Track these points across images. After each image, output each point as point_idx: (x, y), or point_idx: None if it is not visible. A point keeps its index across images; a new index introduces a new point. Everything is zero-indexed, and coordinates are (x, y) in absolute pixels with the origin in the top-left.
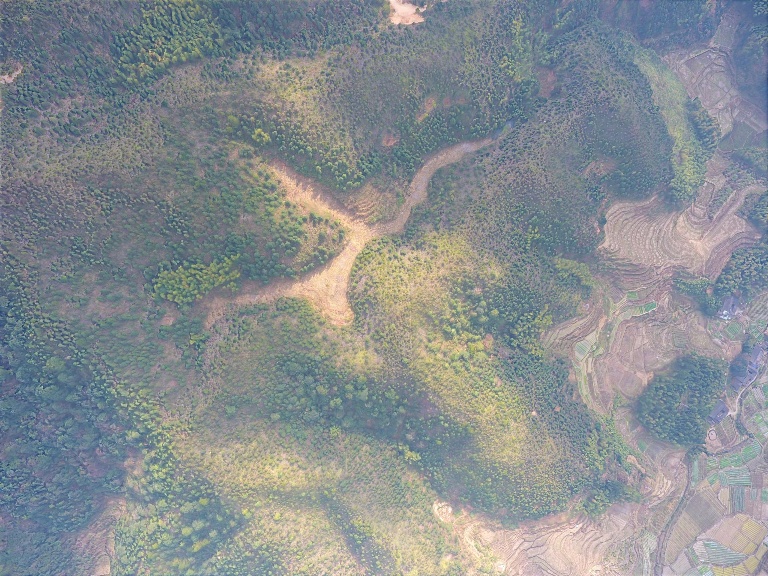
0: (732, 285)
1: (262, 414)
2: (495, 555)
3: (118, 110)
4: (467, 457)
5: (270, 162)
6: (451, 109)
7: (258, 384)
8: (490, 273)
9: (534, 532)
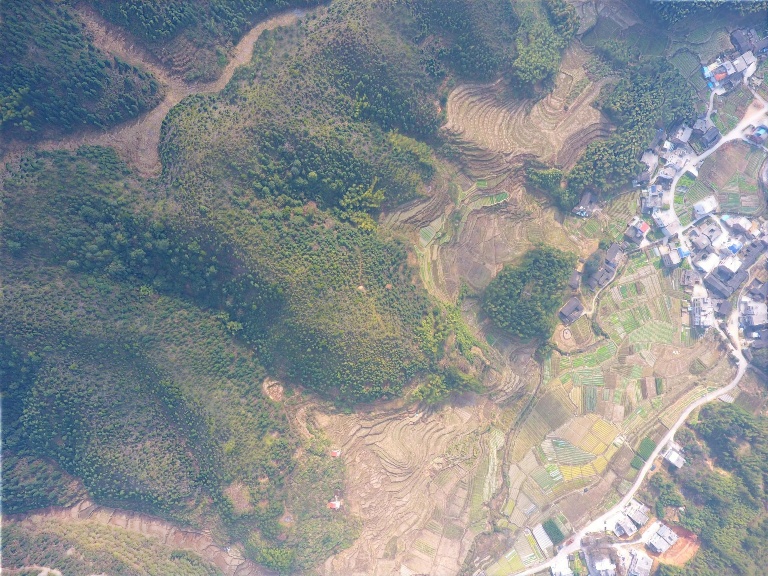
0: (584, 176)
1: (59, 261)
2: (329, 439)
3: None
4: (283, 323)
5: (75, 5)
6: None
7: (46, 222)
8: (302, 130)
9: (371, 418)
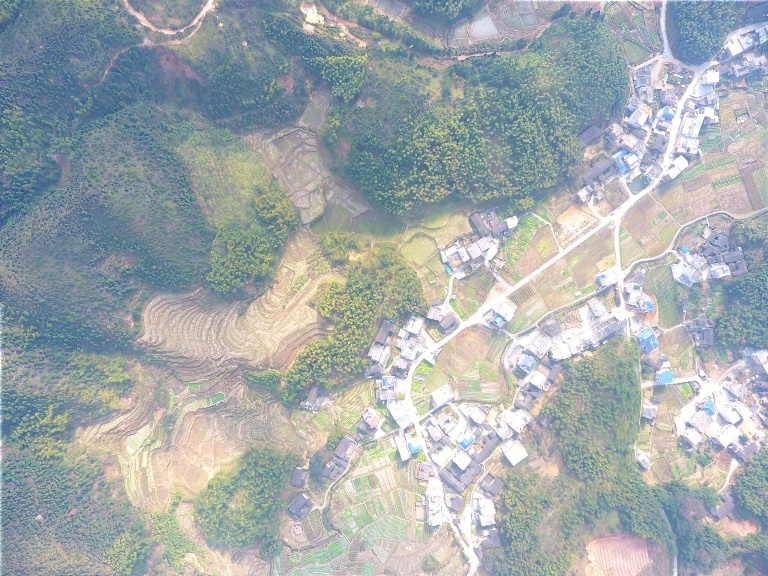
0: (299, 379)
1: None
2: None
3: None
4: None
5: None
6: None
7: None
8: None
9: None
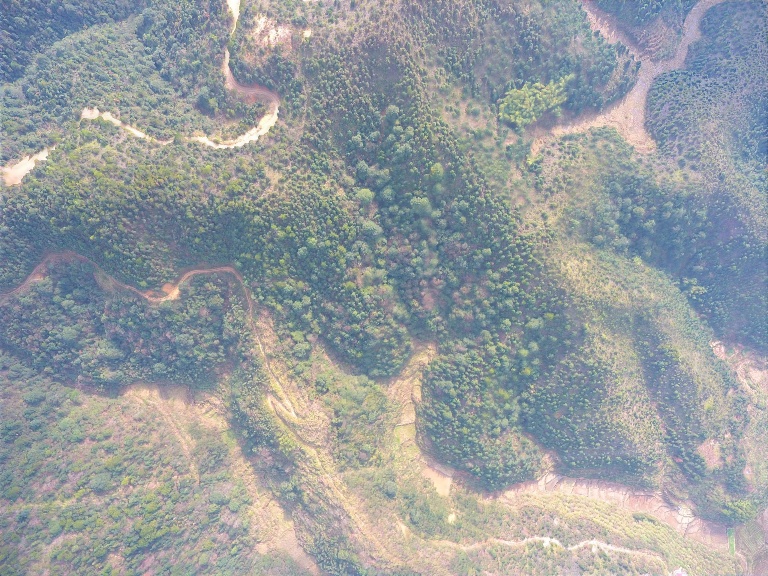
0: None
1: (586, 237)
2: (764, 393)
3: None
4: (760, 281)
5: None
6: None
7: None
8: None
9: None
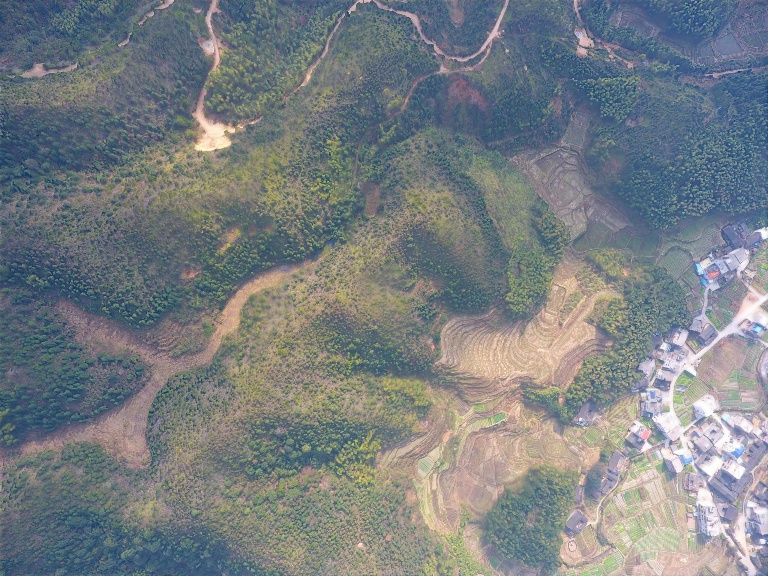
0: (582, 395)
1: (46, 570)
2: None
3: None
4: None
5: (55, 303)
6: (257, 237)
7: (31, 545)
8: (294, 411)
9: None
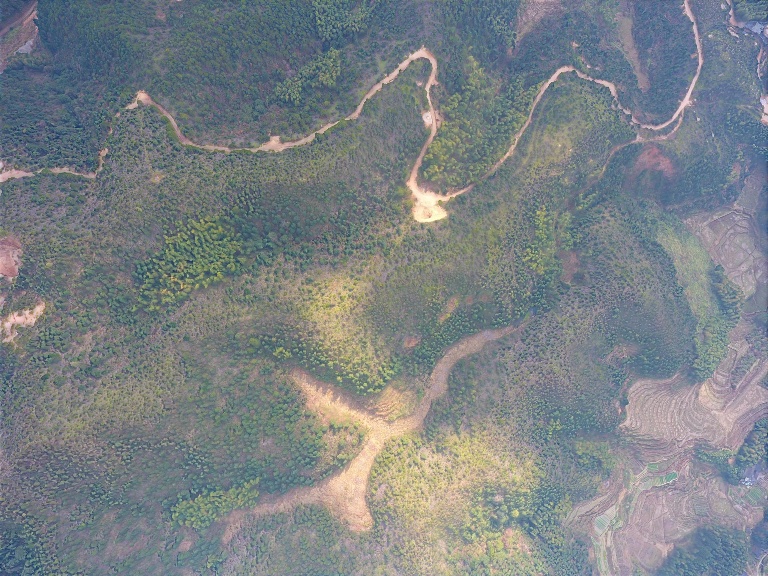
0: (755, 458)
1: None
2: None
3: (139, 344)
4: None
5: (290, 371)
6: (473, 307)
7: None
8: (512, 480)
9: None
